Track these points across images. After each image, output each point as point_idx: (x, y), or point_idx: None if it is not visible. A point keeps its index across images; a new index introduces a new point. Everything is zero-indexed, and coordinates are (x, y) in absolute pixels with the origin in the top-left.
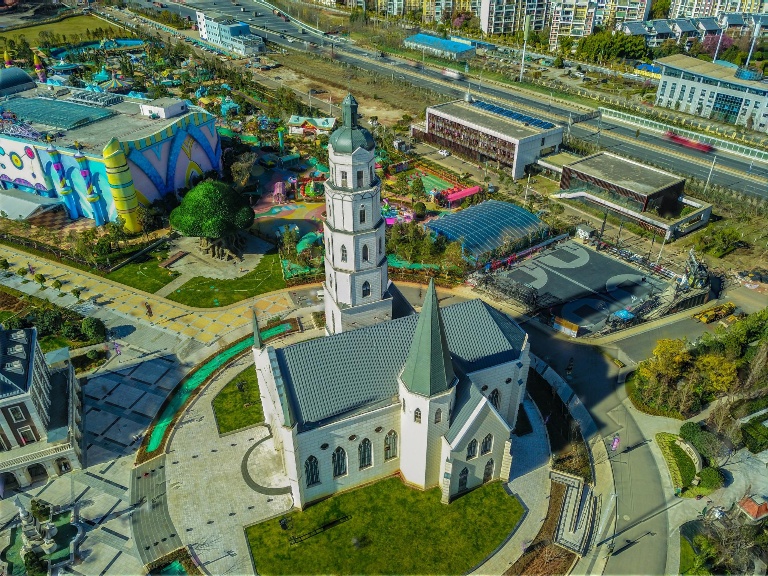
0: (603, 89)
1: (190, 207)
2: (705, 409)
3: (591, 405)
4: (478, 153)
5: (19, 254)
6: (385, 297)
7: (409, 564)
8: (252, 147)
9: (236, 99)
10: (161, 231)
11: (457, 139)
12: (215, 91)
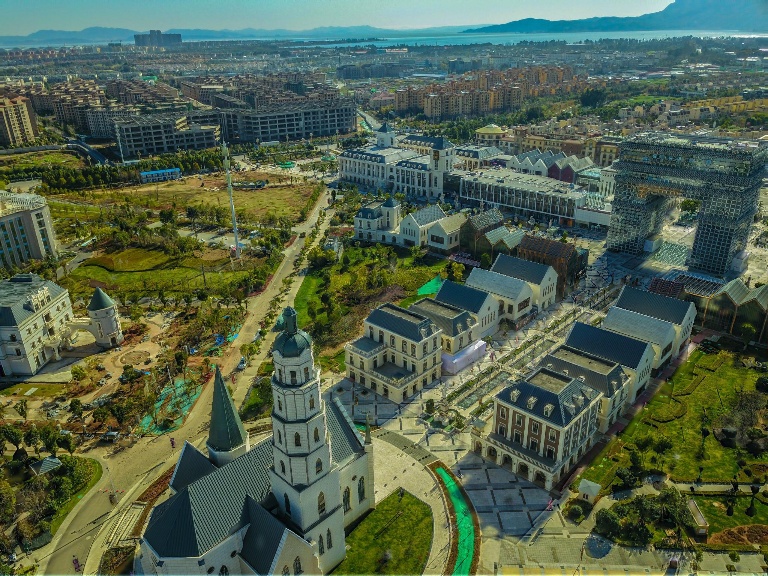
0: None
1: None
2: None
3: None
4: None
5: None
6: None
7: None
8: None
9: None
10: None
11: None
12: None
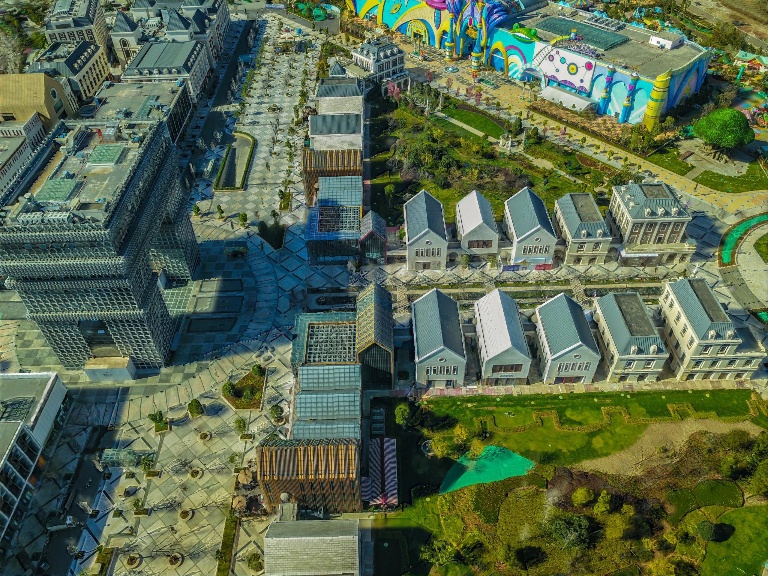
0: None
1: (718, 124)
2: None
3: None
4: None
5: (579, 134)
6: None
7: None
8: None
9: (680, 26)
10: (667, 134)
11: None
12: (652, 14)
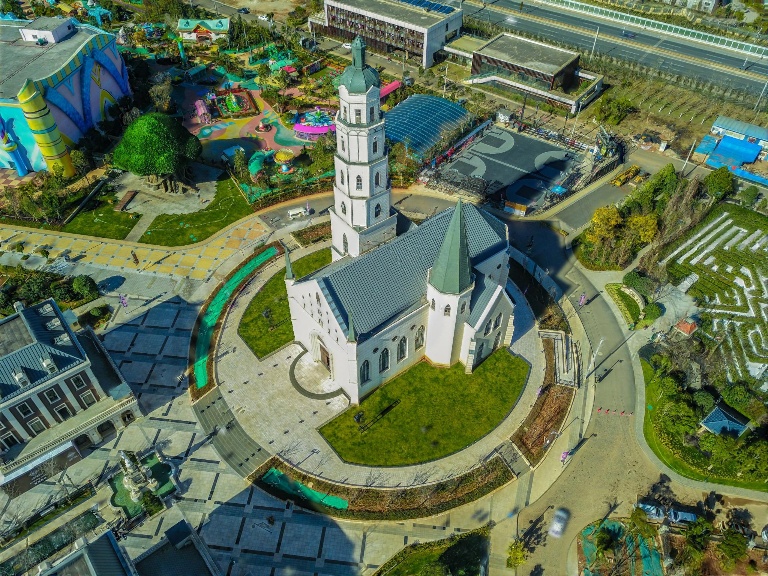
0: None
1: (137, 145)
2: (635, 259)
3: (552, 272)
4: (385, 44)
5: None
6: (391, 214)
7: (458, 425)
8: (146, 61)
9: (103, 3)
10: (96, 172)
11: (361, 31)
12: None
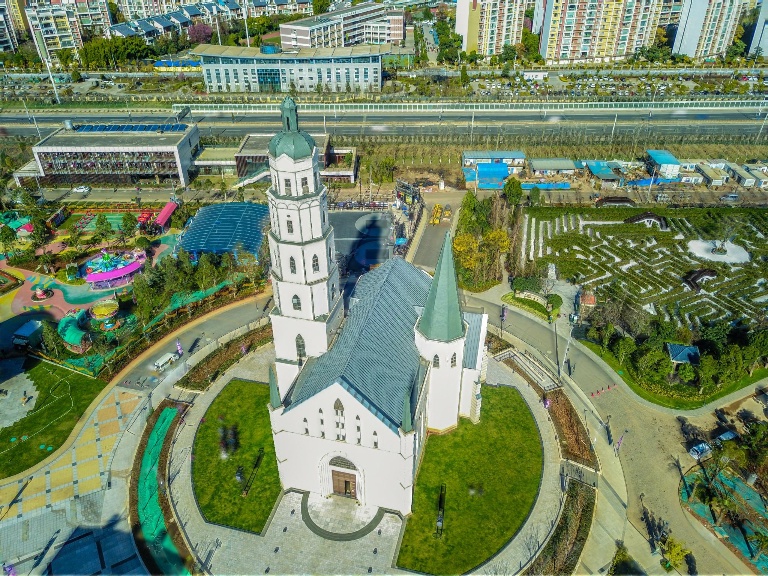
0: (149, 90)
1: None
2: None
3: None
4: (128, 175)
5: None
6: None
7: (514, 473)
8: None
9: None
10: None
11: (92, 169)
12: None
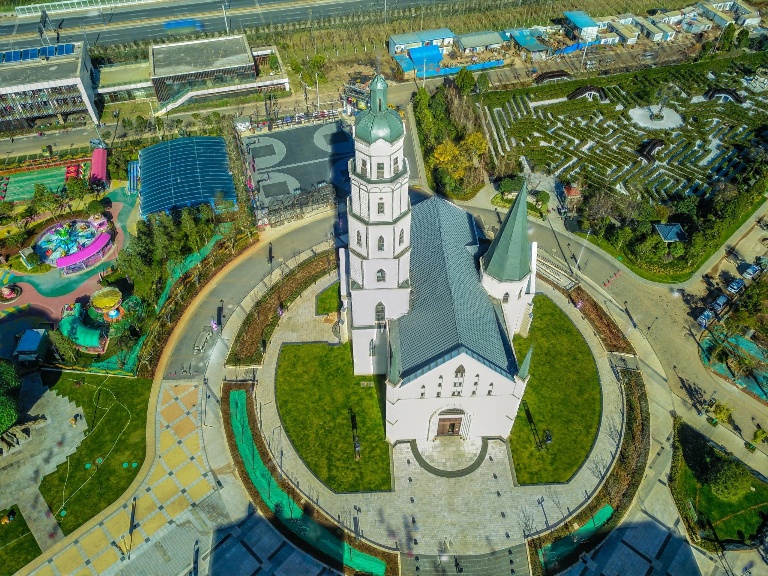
0: None
1: None
2: None
3: None
4: (24, 120)
5: None
6: None
7: (575, 375)
8: None
9: None
10: None
11: None
12: None
